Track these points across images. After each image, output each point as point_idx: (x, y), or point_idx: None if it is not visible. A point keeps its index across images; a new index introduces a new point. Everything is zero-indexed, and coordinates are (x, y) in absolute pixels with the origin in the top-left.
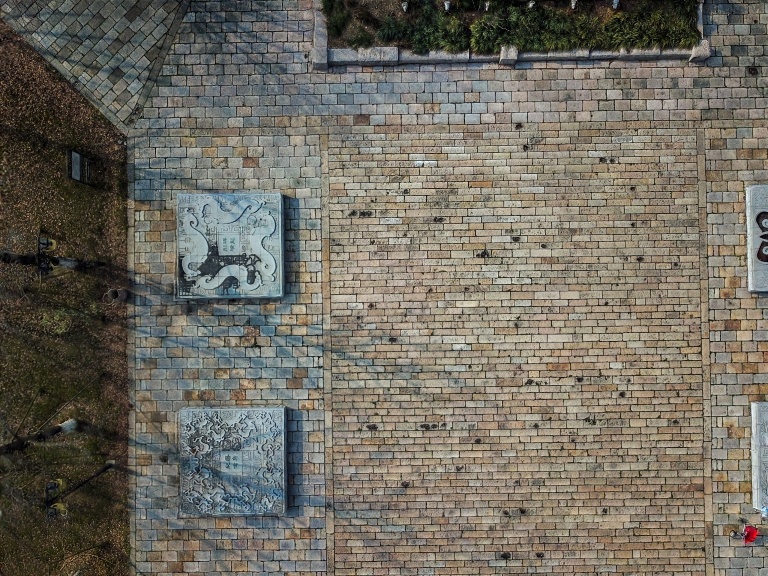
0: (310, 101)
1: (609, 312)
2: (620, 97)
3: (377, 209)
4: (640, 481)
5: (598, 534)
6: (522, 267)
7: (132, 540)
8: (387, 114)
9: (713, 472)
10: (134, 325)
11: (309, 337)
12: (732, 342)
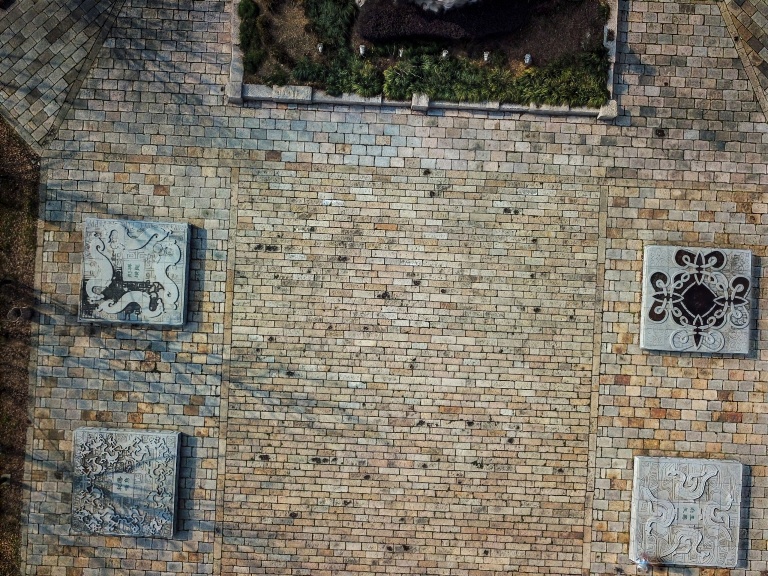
0: (224, 134)
1: (503, 360)
2: (528, 150)
3: (283, 244)
4: (522, 526)
5: (478, 575)
6: (421, 310)
7: (23, 553)
8: (299, 151)
9: (593, 521)
10: (37, 343)
11: (208, 366)
12: (621, 396)
